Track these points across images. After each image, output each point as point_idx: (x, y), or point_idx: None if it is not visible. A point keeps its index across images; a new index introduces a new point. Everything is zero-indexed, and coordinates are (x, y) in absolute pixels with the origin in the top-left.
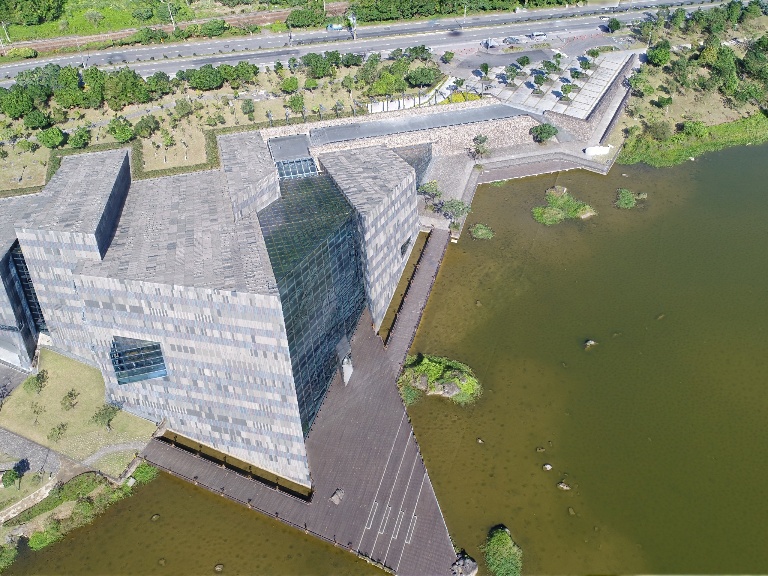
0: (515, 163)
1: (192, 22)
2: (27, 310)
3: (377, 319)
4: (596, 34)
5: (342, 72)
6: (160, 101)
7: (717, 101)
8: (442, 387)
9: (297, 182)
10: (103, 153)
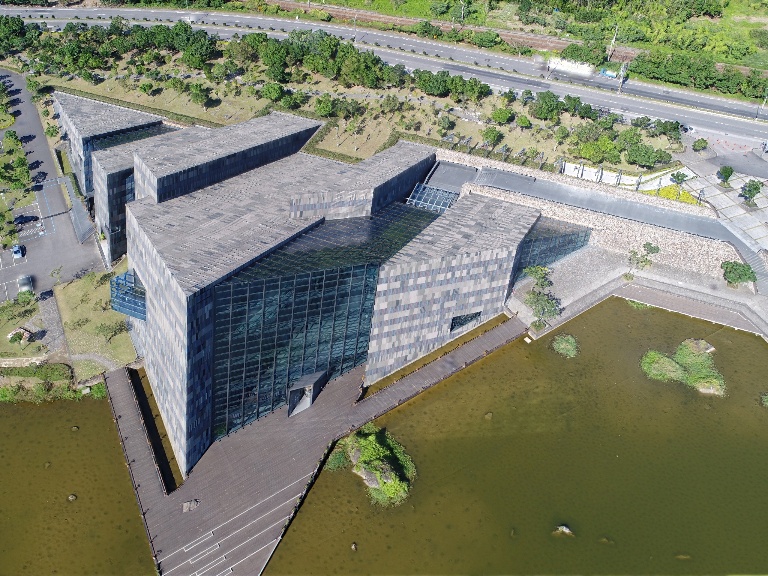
0: (677, 292)
1: (479, 28)
2: None
3: (373, 373)
4: None
5: (572, 121)
6: (385, 91)
7: None
8: None
9: (407, 209)
10: (303, 119)
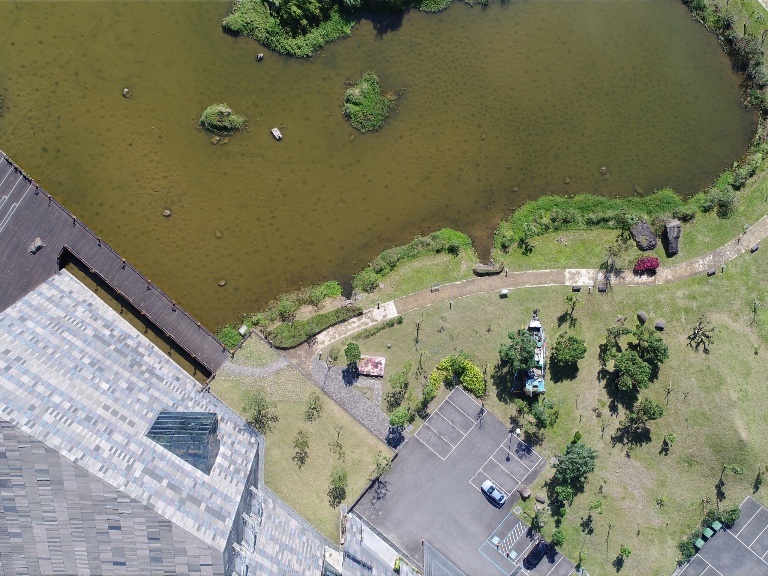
0: None
1: None
2: None
3: None
4: None
5: None
6: None
7: None
8: None
9: None
10: None
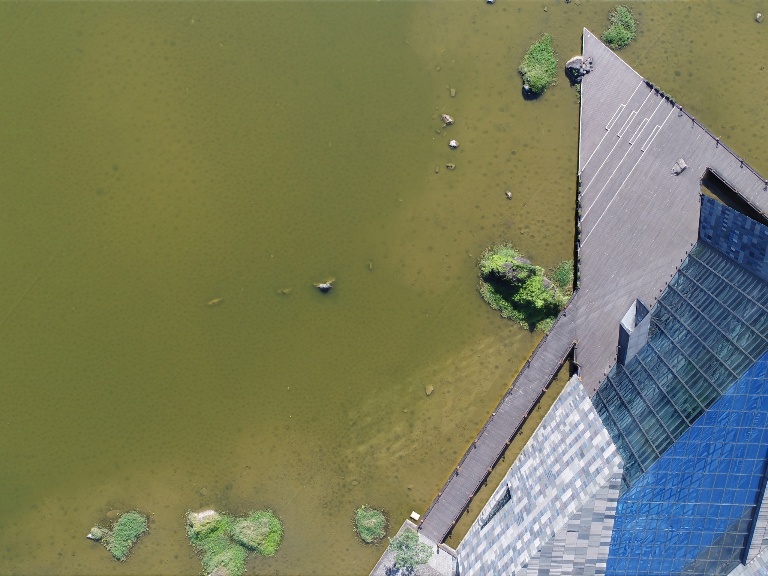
0: None
1: None
2: None
3: None
4: None
5: None
6: None
7: None
8: None
9: None
10: None
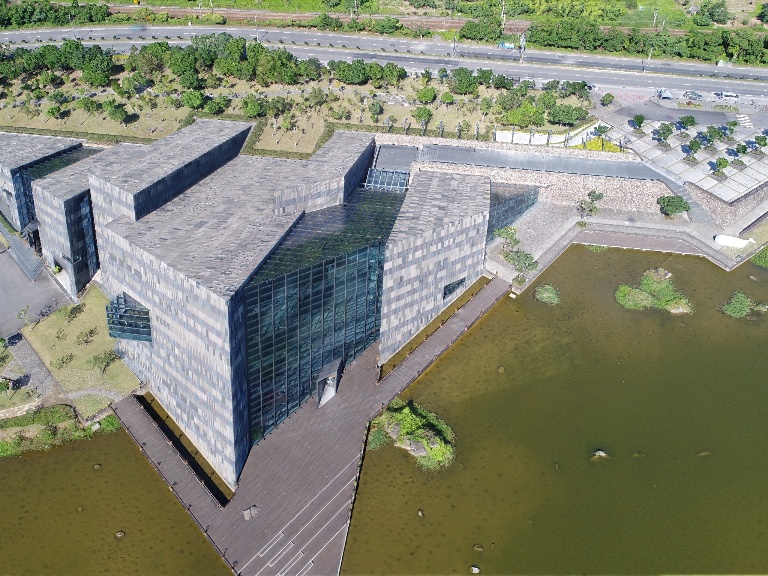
0: (626, 231)
1: (374, 16)
2: (91, 247)
3: (385, 351)
4: None
5: (489, 93)
6: (304, 85)
7: None
8: (410, 443)
9: (372, 193)
10: (231, 123)
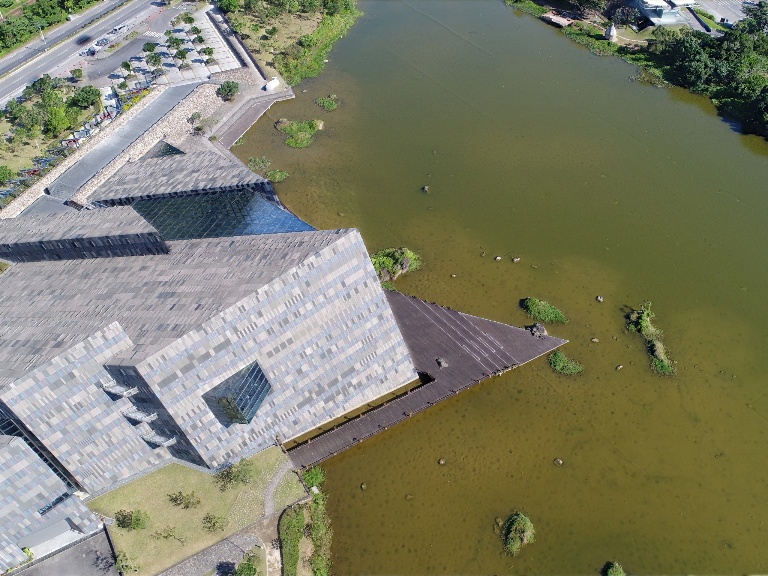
0: (232, 122)
1: None
2: None
3: None
4: (158, 10)
5: None
6: None
7: (294, 19)
8: (400, 266)
9: None
10: None
